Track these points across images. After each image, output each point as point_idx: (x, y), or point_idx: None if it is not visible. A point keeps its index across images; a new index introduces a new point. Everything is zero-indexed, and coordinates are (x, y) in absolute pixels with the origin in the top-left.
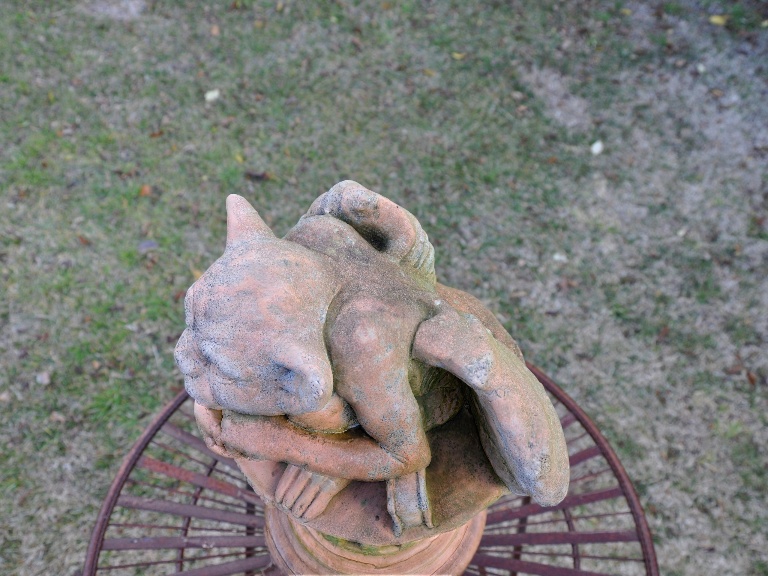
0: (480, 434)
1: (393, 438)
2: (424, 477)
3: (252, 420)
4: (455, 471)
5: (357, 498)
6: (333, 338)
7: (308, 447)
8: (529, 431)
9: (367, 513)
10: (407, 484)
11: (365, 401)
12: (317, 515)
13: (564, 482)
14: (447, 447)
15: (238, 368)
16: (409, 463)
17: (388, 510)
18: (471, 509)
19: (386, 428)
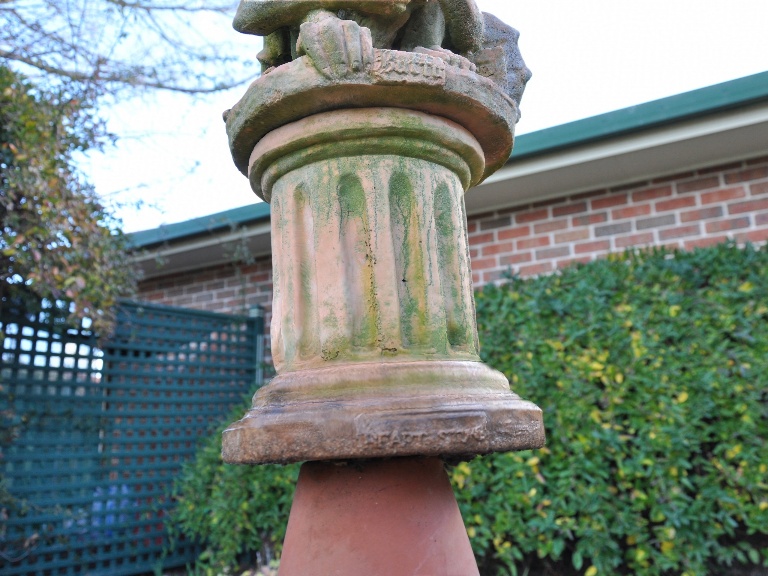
0: None
1: None
2: None
3: None
4: None
5: None
6: None
7: None
8: None
9: None
10: None
11: None
12: None
13: None
14: None
15: None
16: None
17: (501, 47)
18: None
19: None
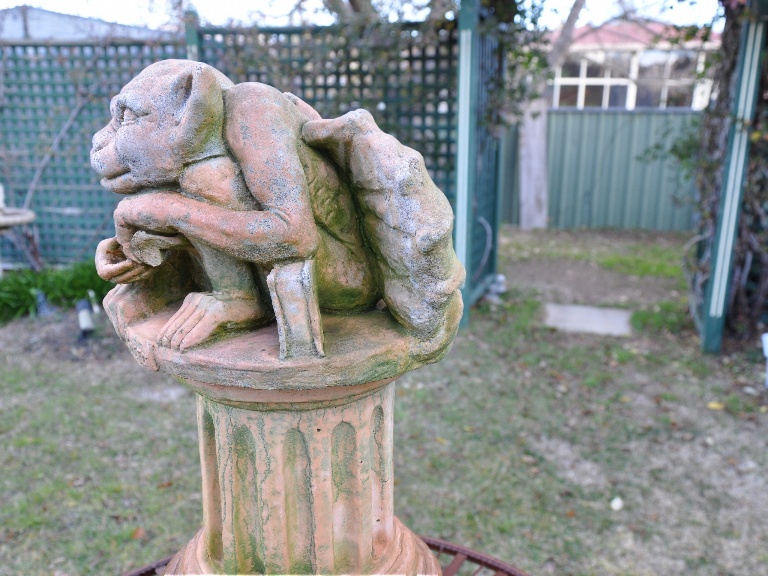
0: (384, 290)
1: (276, 187)
2: (311, 264)
3: (147, 193)
4: (358, 331)
5: (246, 341)
6: (229, 89)
7: (194, 203)
8: (400, 149)
9: (253, 348)
10: (292, 266)
11: (251, 140)
12: (197, 341)
13: (444, 216)
14: (353, 322)
15: (142, 101)
16: (292, 223)
17: (267, 279)
18: (370, 348)
19: (269, 173)
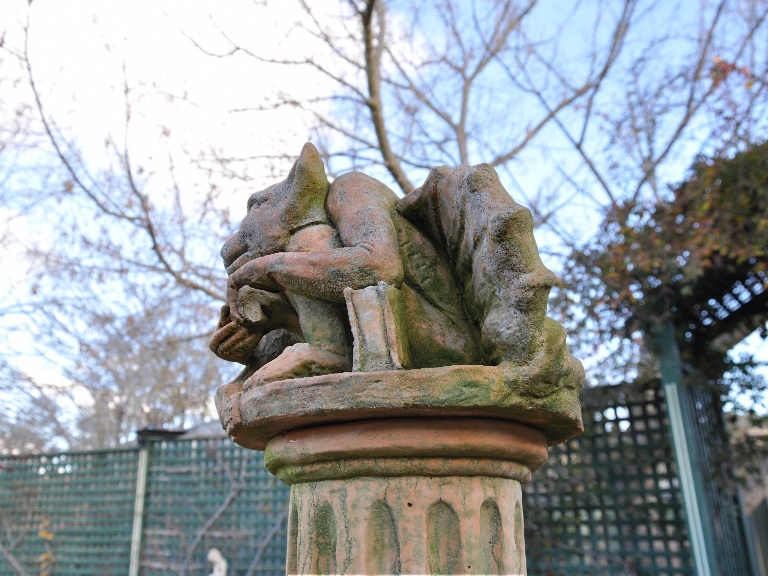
0: None
1: (363, 227)
2: None
3: None
4: None
5: None
6: None
7: None
8: None
9: None
10: None
11: None
12: (277, 373)
13: None
14: None
15: None
16: (374, 251)
17: None
18: None
19: None
